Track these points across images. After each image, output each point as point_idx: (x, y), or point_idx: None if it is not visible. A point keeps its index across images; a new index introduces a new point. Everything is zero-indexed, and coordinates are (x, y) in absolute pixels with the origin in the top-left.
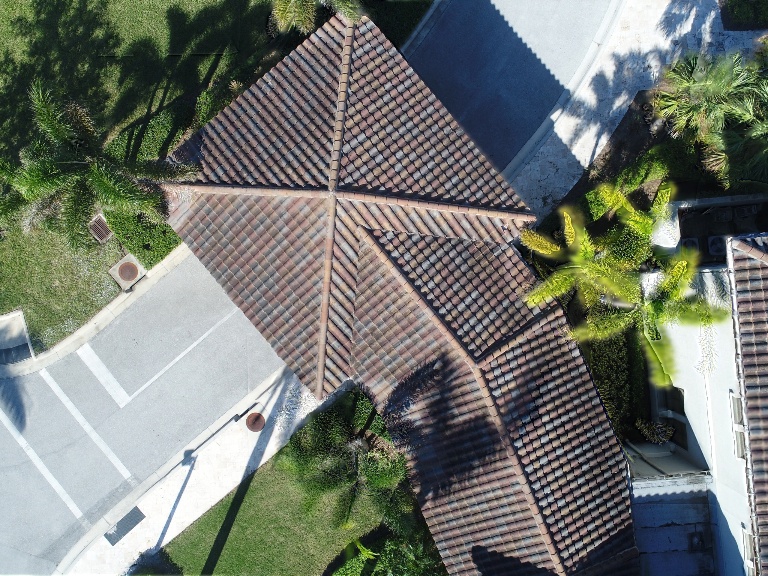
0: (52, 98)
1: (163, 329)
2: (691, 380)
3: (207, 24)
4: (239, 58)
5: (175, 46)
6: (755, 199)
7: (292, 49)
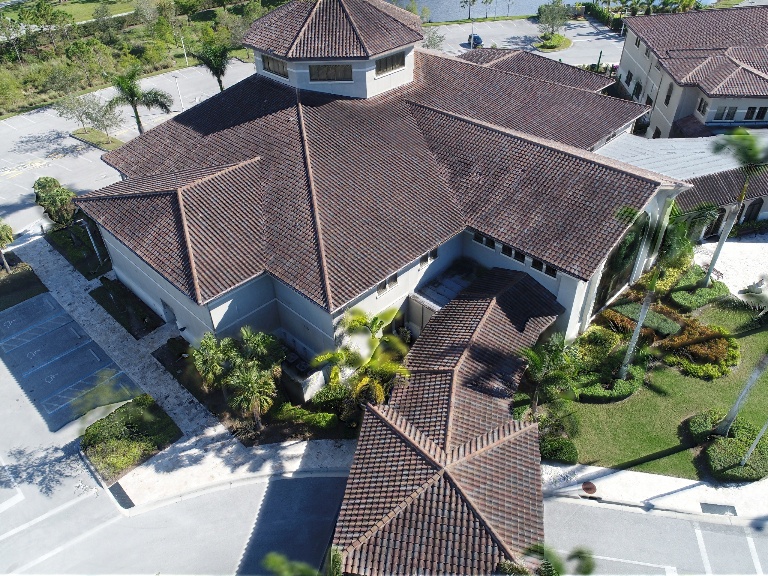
0: None
1: None
2: None
3: None
4: None
5: None
6: None
7: None
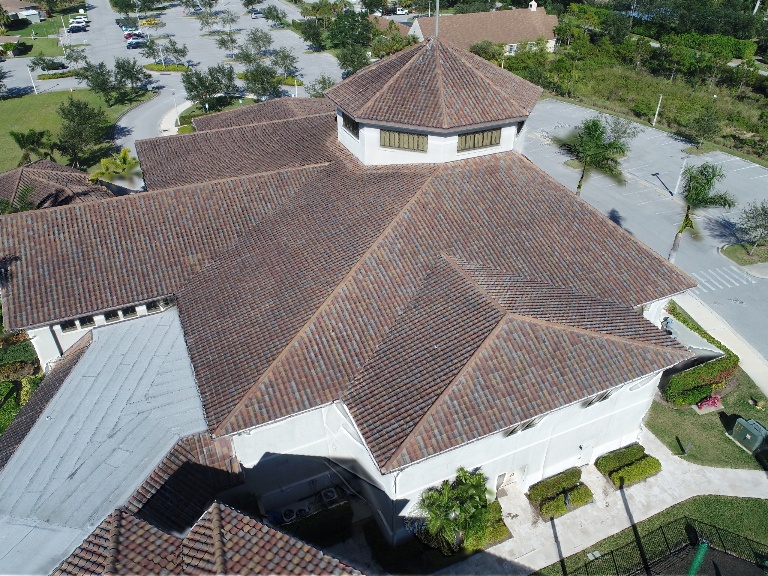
0: None
1: None
2: None
3: None
4: None
5: None
6: None
7: None
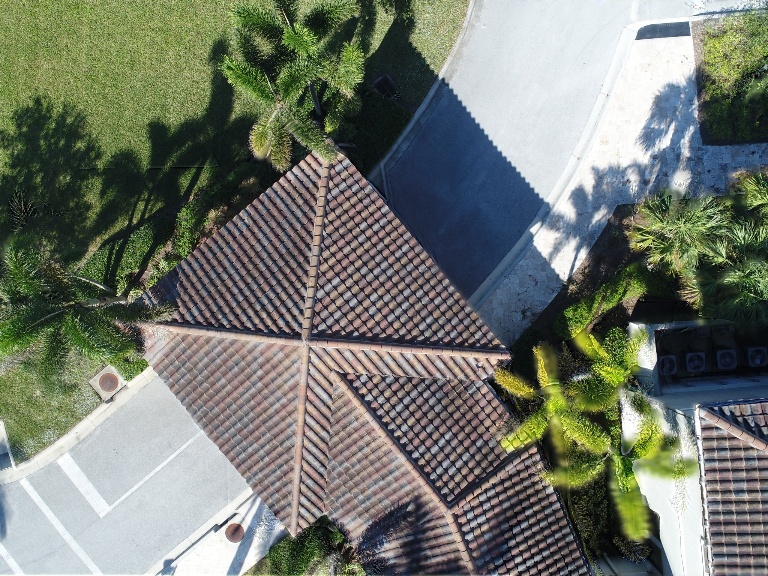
0: (34, 209)
1: (143, 439)
2: (666, 510)
3: (188, 137)
4: (220, 173)
5: (156, 159)
6: (732, 321)
7: (268, 186)
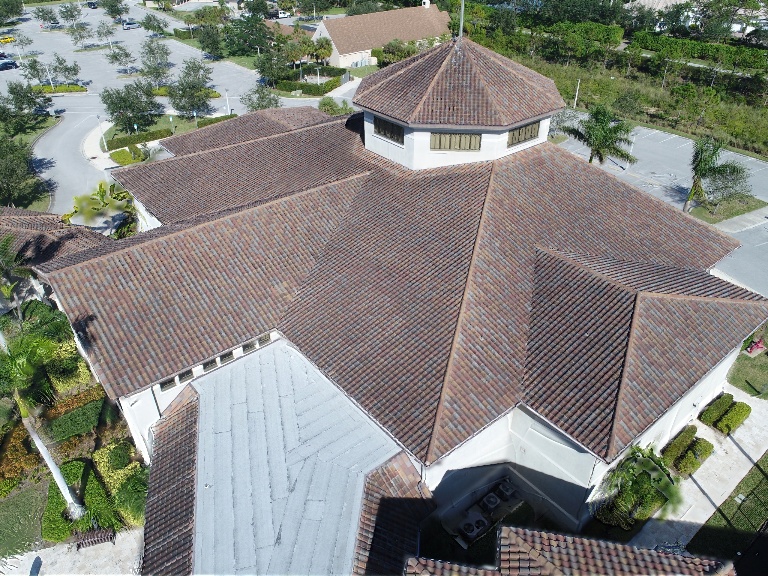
0: None
1: None
2: None
3: None
4: None
5: None
6: None
7: None
